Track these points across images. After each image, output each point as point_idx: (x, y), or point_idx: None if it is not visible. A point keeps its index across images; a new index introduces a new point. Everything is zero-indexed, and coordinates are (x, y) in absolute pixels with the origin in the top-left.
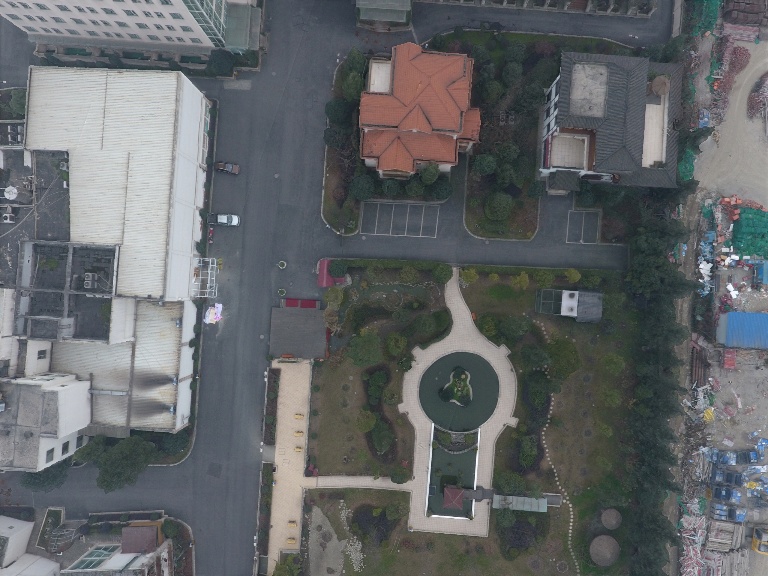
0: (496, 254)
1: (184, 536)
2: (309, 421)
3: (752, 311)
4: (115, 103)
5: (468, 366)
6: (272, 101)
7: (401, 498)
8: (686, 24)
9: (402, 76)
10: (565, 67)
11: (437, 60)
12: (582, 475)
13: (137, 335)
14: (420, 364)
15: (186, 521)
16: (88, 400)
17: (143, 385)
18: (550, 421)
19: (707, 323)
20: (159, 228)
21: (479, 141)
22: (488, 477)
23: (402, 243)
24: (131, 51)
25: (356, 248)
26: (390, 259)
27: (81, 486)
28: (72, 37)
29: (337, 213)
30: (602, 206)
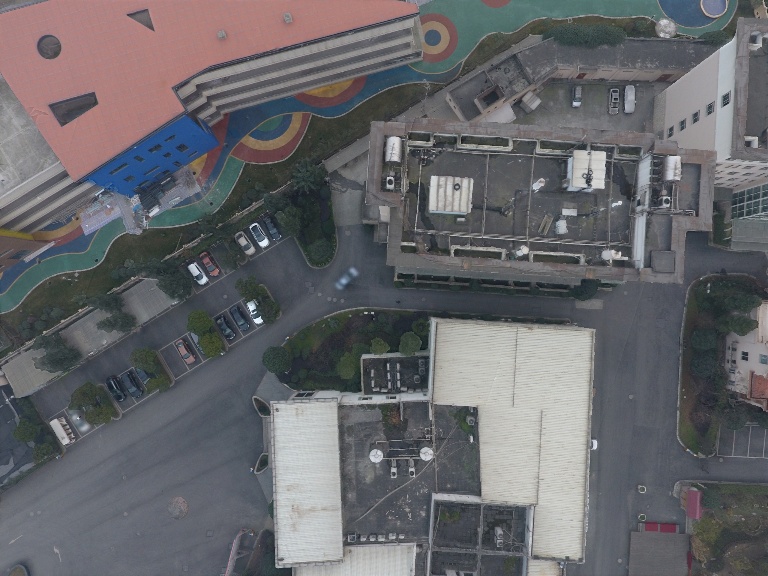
0: None
1: None
2: None
3: None
4: (526, 360)
5: None
6: (625, 321)
7: None
8: None
9: None
10: None
11: None
12: None
13: None
14: None
15: None
16: None
17: None
18: None
19: None
20: (576, 488)
21: None
22: None
23: (760, 465)
24: None
25: (713, 470)
26: (749, 482)
27: None
28: None
29: (694, 435)
30: None
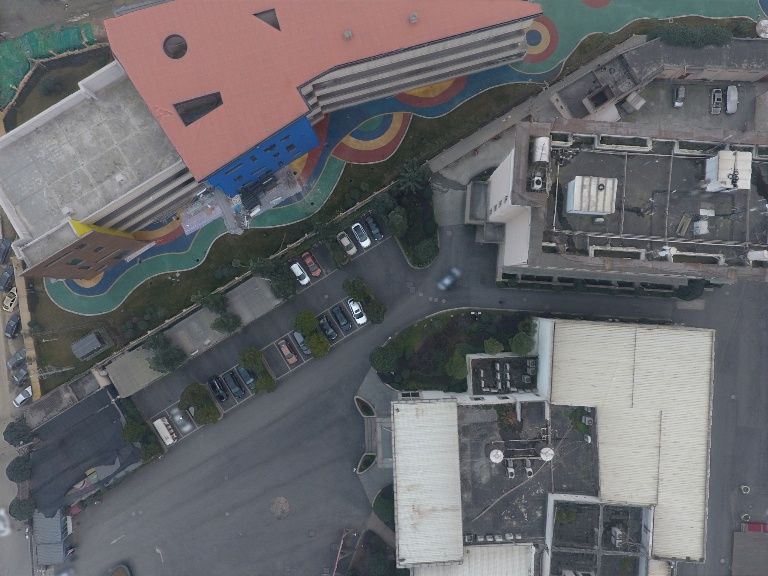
0: None
1: None
2: None
3: None
4: (645, 360)
5: None
6: (726, 321)
7: None
8: None
9: None
10: None
11: None
12: None
13: None
14: None
15: None
16: None
17: None
18: None
19: None
20: (696, 489)
21: None
22: None
23: None
24: None
25: None
26: None
27: None
28: (549, 269)
29: None
30: None
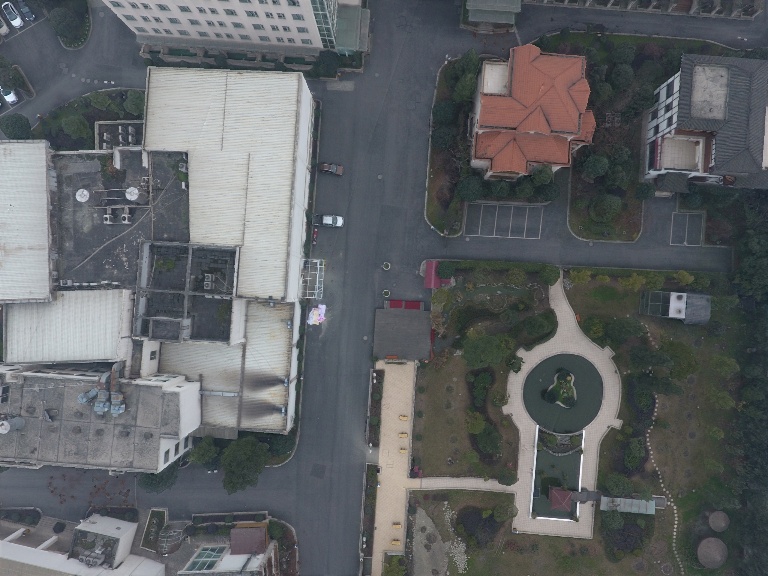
0: (600, 256)
1: (288, 537)
2: (413, 422)
3: None
4: (235, 104)
5: (572, 368)
6: (375, 102)
7: (505, 500)
8: None
9: (522, 78)
10: (686, 69)
11: (557, 62)
12: (686, 477)
13: (247, 336)
14: (524, 366)
15: (290, 522)
16: (199, 401)
17: (253, 386)
18: (655, 423)
19: None
20: (280, 229)
21: (592, 143)
22: (592, 479)
23: (506, 245)
24: (235, 52)
25: (460, 249)
26: (494, 260)
27: (184, 487)
28: (180, 38)
29: (441, 214)
30: (706, 208)
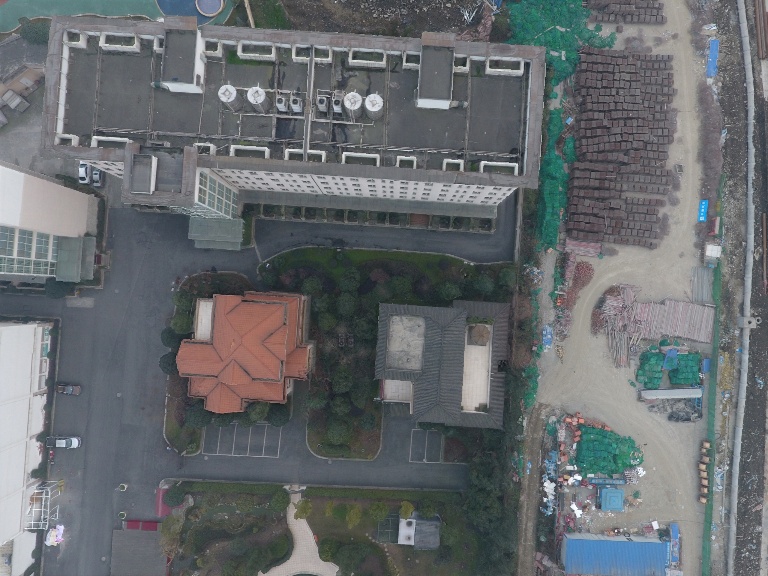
0: (339, 474)
1: None
2: None
3: (597, 530)
4: None
5: None
6: (115, 319)
7: None
8: (527, 242)
9: (220, 328)
10: (382, 319)
11: (255, 312)
12: None
13: None
14: None
15: None
16: None
17: None
18: None
19: (549, 545)
20: None
21: None
22: None
23: (244, 463)
24: None
25: (198, 468)
26: (232, 480)
27: None
28: None
29: (179, 433)
30: None
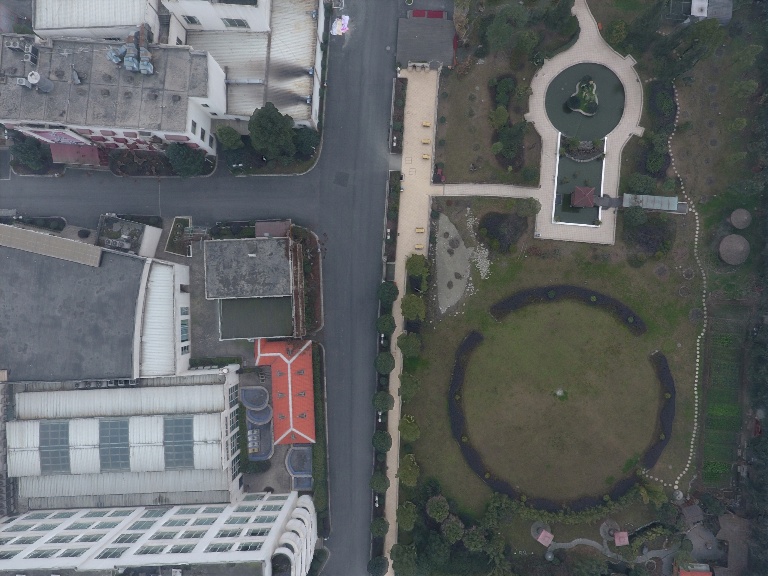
0: None
1: (311, 243)
2: (436, 130)
3: None
4: None
5: (593, 78)
6: None
7: None
8: None
9: None
10: None
11: None
12: (708, 184)
13: (273, 26)
14: (546, 75)
15: (313, 229)
16: (224, 90)
17: (278, 76)
18: (676, 129)
19: None
20: None
21: None
22: (614, 186)
23: None
24: None
25: None
26: None
27: (208, 196)
28: None
29: None
30: None
